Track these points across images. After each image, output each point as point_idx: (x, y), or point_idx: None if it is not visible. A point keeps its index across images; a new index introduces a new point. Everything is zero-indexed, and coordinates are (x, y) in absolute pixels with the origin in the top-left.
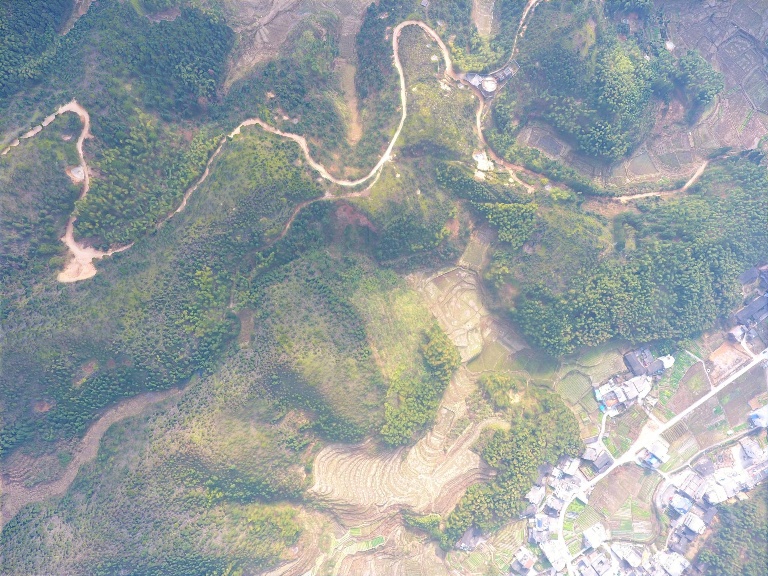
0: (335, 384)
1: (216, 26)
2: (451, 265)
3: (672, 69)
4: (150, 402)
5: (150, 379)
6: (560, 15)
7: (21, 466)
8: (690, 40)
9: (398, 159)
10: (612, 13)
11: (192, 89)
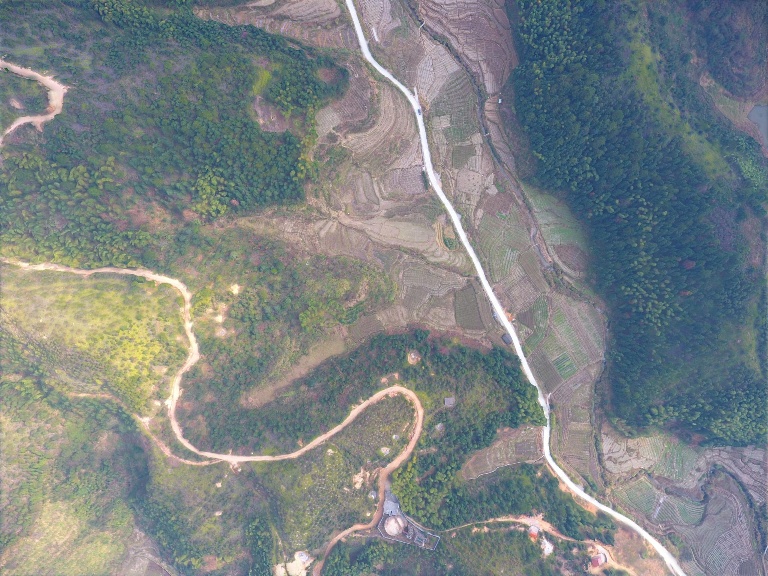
0: None
1: (292, 180)
2: None
3: None
4: None
5: None
6: (518, 568)
7: None
8: None
9: (238, 475)
10: None
11: (194, 196)
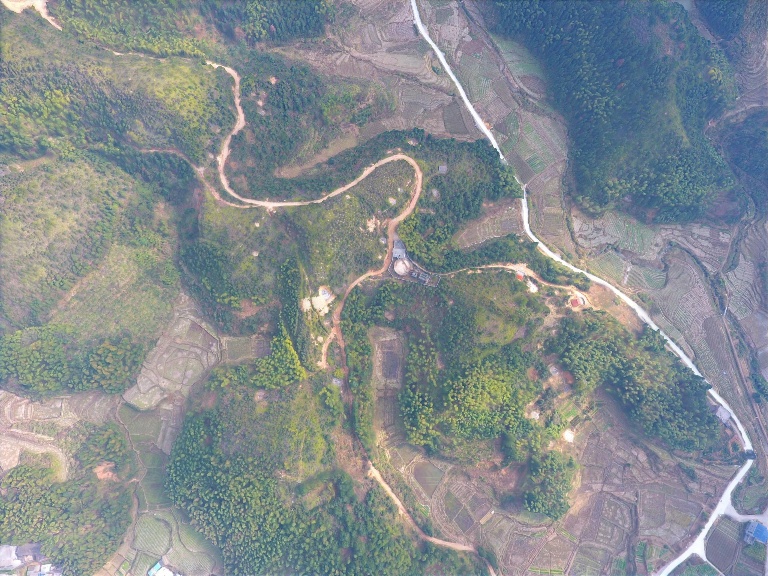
0: (2, 264)
1: (316, 14)
2: (217, 331)
3: (536, 447)
4: None
5: None
6: (508, 297)
7: None
8: (590, 455)
9: (273, 217)
10: (550, 350)
11: (243, 19)
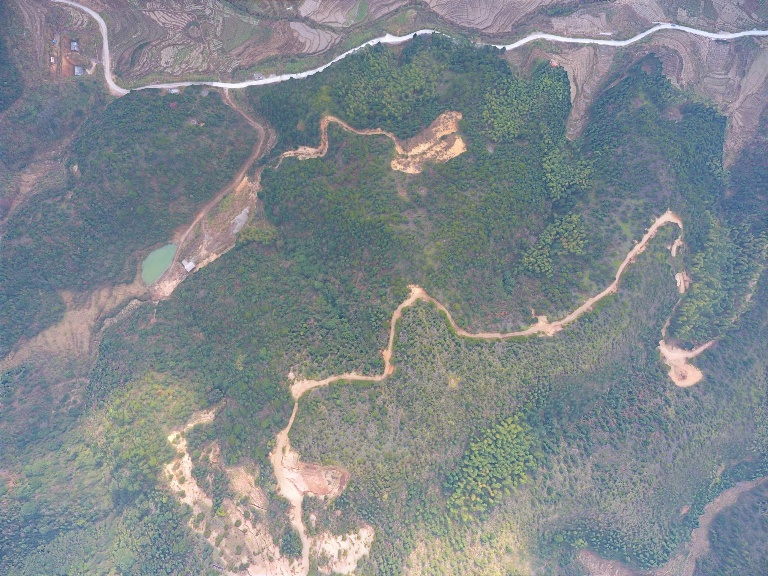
0: None
1: (719, 118)
2: None
3: None
4: (742, 490)
5: (760, 470)
6: None
7: (666, 568)
8: None
9: None
10: None
11: (719, 183)
